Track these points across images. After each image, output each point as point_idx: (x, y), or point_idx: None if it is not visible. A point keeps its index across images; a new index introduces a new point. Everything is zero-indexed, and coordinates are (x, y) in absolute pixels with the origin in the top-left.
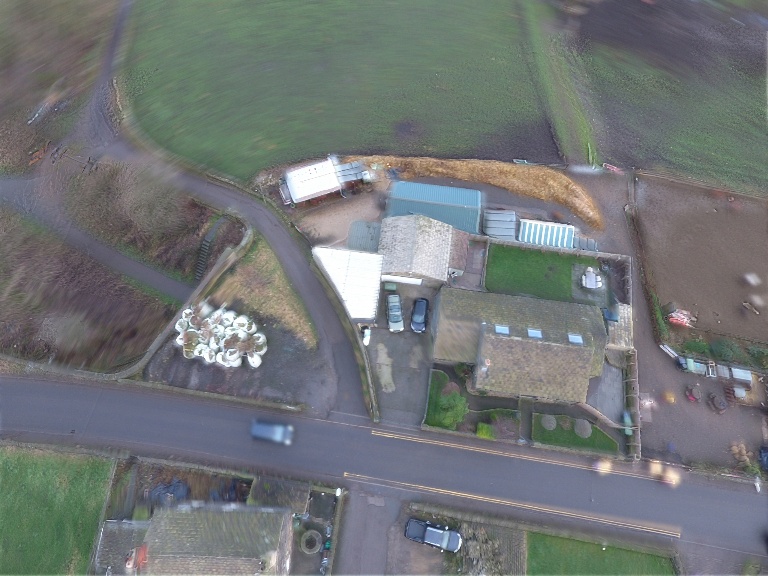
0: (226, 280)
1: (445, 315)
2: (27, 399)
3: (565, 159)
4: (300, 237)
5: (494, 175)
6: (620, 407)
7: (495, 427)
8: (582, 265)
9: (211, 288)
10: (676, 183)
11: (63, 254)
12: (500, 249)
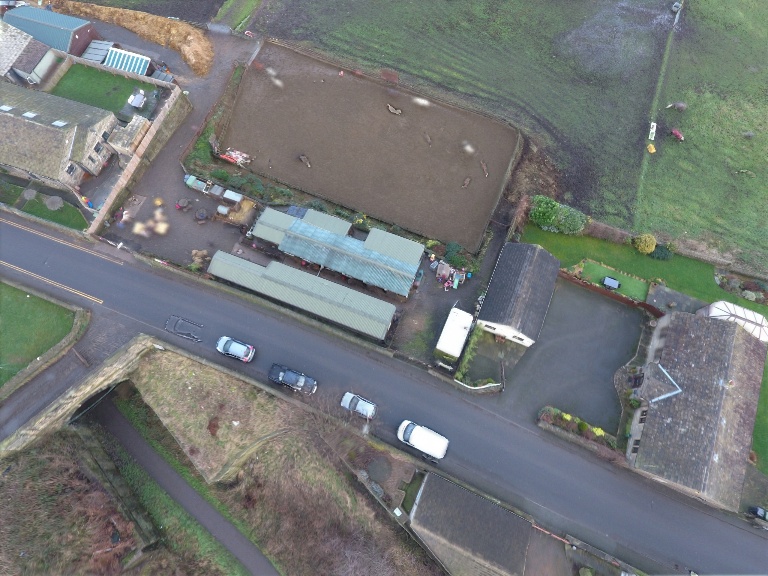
0: None
1: None
2: None
3: None
4: None
5: (130, 20)
6: None
7: None
8: (143, 90)
9: None
10: (300, 54)
11: None
12: (82, 68)
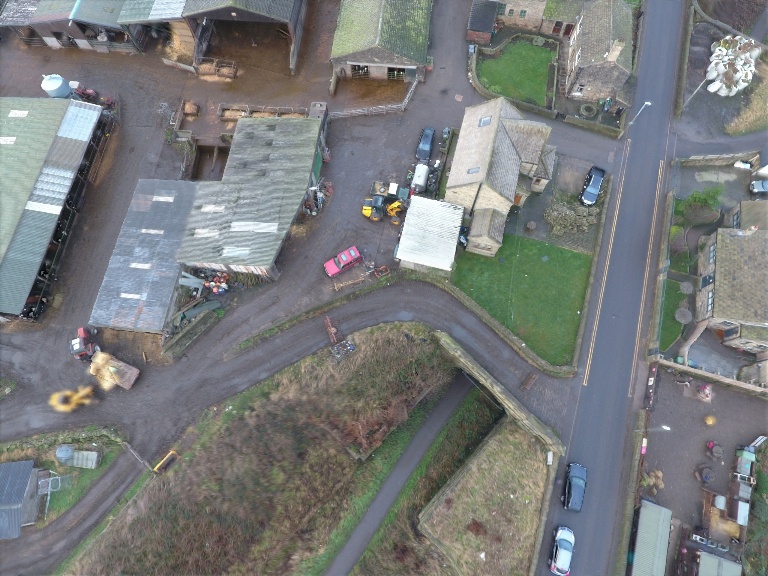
0: None
1: None
2: None
3: None
4: None
5: None
6: None
7: None
8: None
9: None
10: None
11: None
12: None
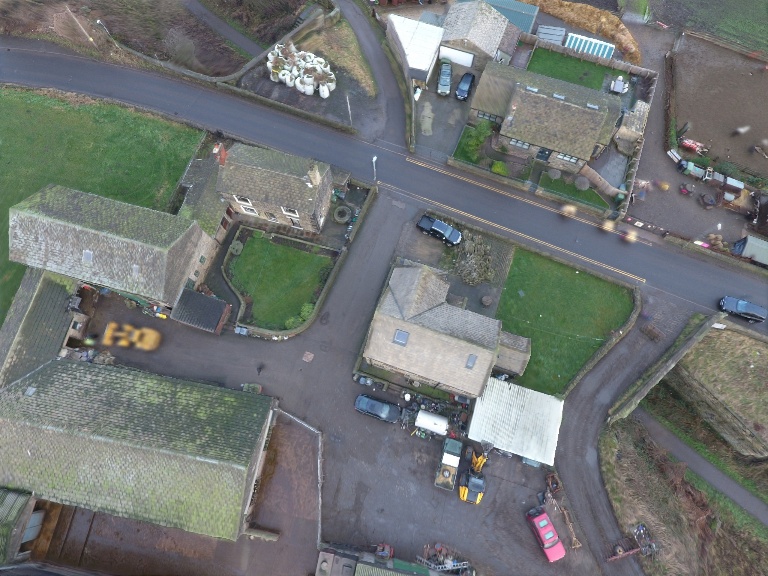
0: (313, 36)
1: (487, 73)
2: (146, 86)
3: (622, 11)
4: (378, 25)
5: (555, 7)
6: (619, 183)
7: (508, 165)
8: (614, 77)
9: (300, 39)
10: (720, 47)
11: (184, 15)
12: (545, 53)
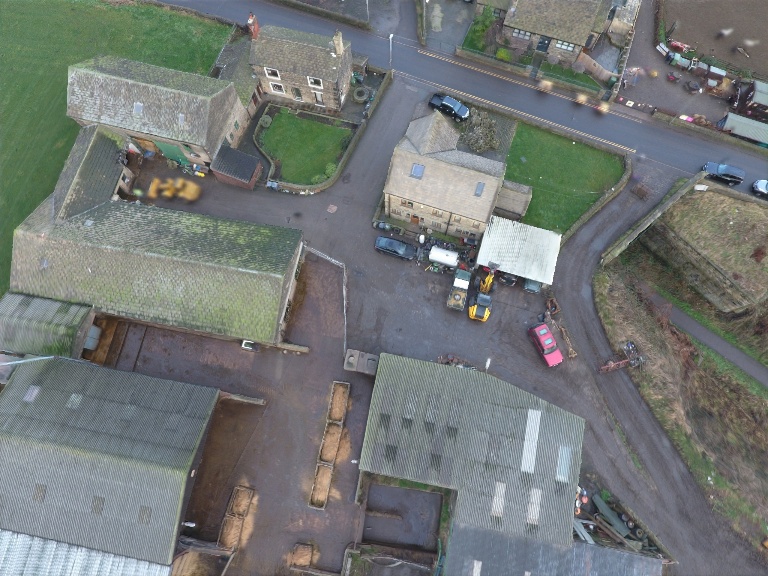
0: None
1: None
2: None
3: None
4: None
5: None
6: (612, 70)
7: (511, 51)
8: None
9: None
10: None
11: None
12: None
